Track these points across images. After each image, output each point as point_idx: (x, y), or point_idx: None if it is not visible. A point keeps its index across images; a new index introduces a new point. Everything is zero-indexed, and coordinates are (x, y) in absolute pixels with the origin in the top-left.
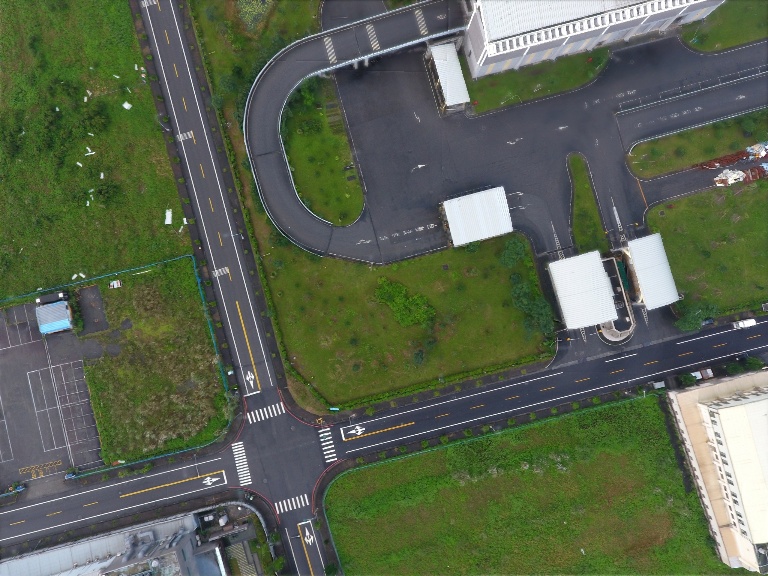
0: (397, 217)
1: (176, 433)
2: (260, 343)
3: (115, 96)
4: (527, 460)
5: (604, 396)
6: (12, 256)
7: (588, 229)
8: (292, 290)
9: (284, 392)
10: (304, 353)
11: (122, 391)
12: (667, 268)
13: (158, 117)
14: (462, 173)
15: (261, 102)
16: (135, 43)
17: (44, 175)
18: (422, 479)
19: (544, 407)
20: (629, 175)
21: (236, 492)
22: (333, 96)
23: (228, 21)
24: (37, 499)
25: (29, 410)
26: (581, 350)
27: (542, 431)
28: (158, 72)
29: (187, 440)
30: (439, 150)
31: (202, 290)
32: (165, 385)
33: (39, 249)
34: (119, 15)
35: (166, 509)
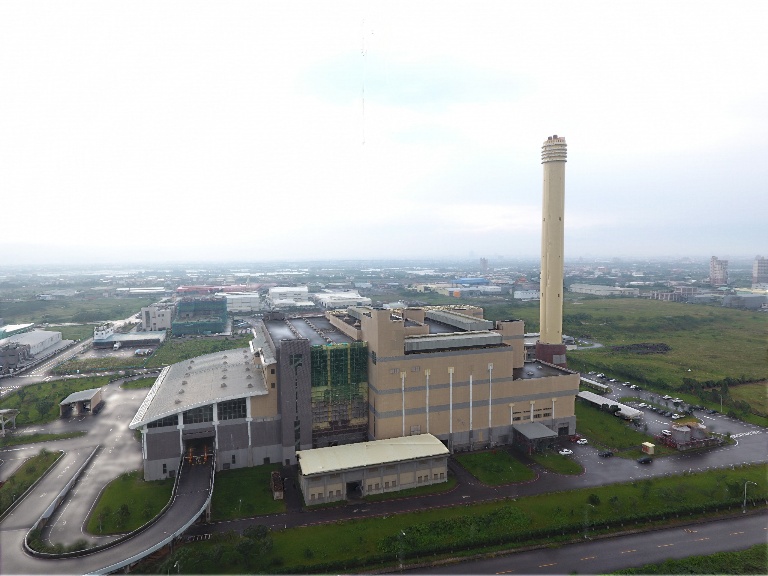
0: None
1: None
2: None
3: None
4: None
5: None
6: None
7: None
8: None
9: None
10: None
11: None
12: None
13: None
14: None
15: None
16: None
17: None
18: None
19: None
20: None
21: None
22: None
23: None
24: None
25: None
26: None
27: None
28: None
29: None
30: None
31: (124, 368)
32: None
33: None
34: None
35: (35, 367)
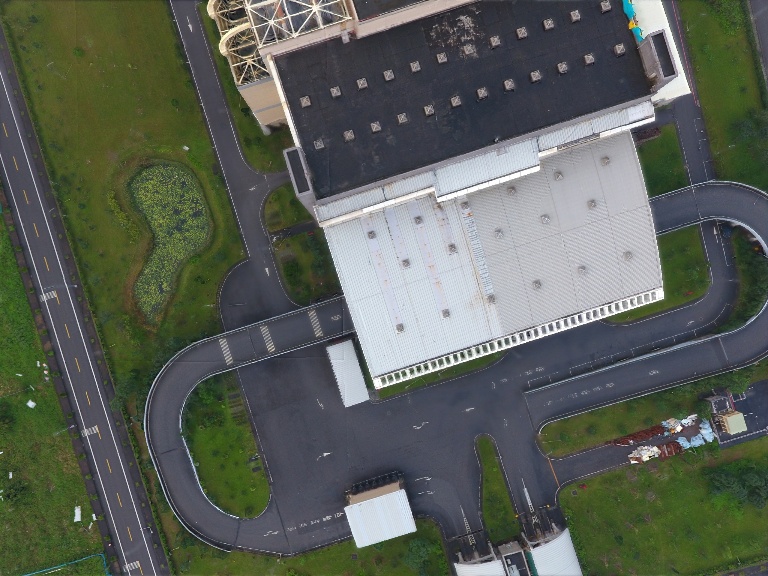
0: (304, 507)
1: None
2: None
3: (18, 396)
4: None
5: None
6: None
7: (498, 513)
8: None
9: None
10: None
11: None
12: (574, 569)
13: (62, 414)
14: (368, 460)
15: (161, 402)
16: (36, 339)
17: None
18: None
19: None
20: (540, 455)
21: None
22: (234, 388)
23: (126, 316)
24: None
25: None
26: None
27: None
28: (60, 367)
29: None
30: (344, 437)
31: None
32: None
33: None
34: (18, 313)
35: None
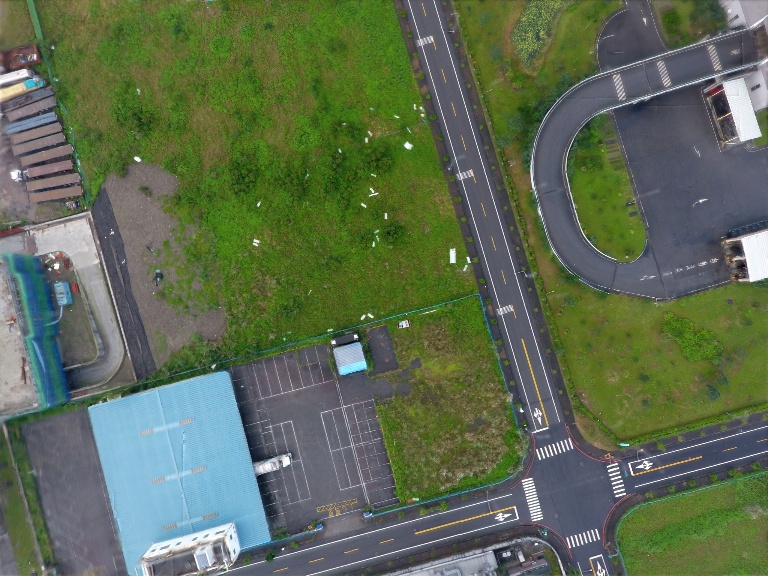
0: (680, 252)
1: (473, 471)
2: (546, 380)
3: (397, 136)
4: None
5: None
6: (303, 298)
7: None
8: (577, 327)
9: (572, 428)
10: (591, 389)
11: (415, 430)
12: None
13: (438, 156)
14: (743, 207)
15: (547, 140)
16: (413, 83)
17: (330, 217)
18: (712, 513)
19: None
20: None
21: (528, 527)
22: (614, 132)
23: (508, 59)
24: (334, 537)
25: (324, 450)
26: None
27: None
28: (436, 111)
29: (483, 477)
30: (720, 184)
31: (489, 328)
32: (456, 423)
33: (328, 290)
34: (397, 55)
35: (460, 545)
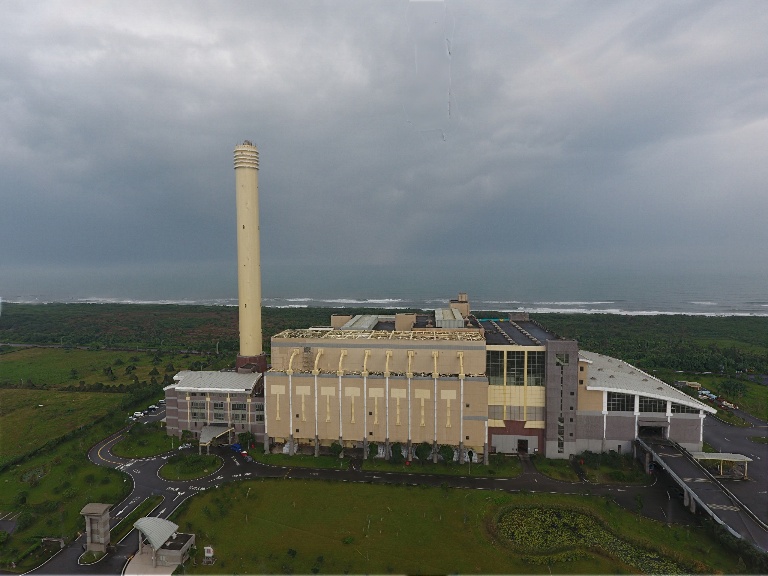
0: None
1: None
2: None
3: None
4: None
5: None
6: None
7: None
8: None
9: None
10: None
11: None
12: None
13: None
14: None
15: None
16: None
17: None
18: None
19: None
20: None
21: None
22: None
23: None
24: None
25: None
26: None
27: None
28: None
29: None
30: None
31: None
32: None
33: None
34: None
35: None
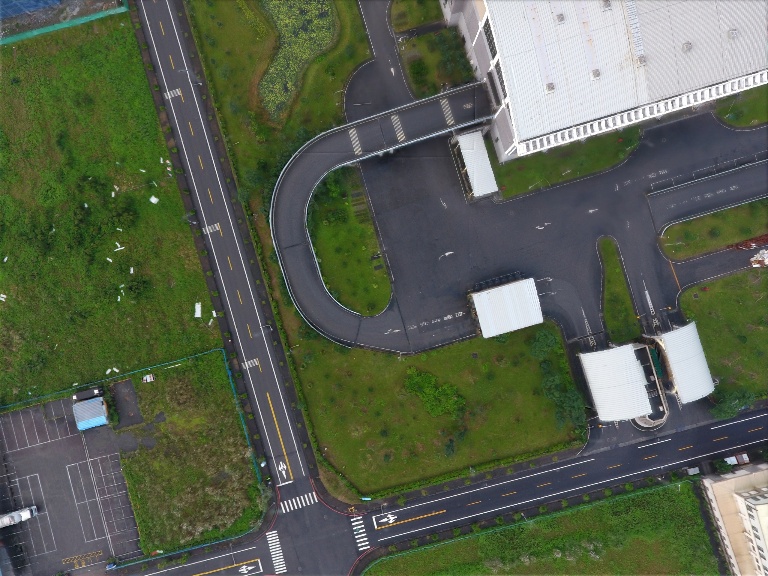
0: (425, 306)
1: (212, 525)
2: (291, 433)
3: (142, 191)
4: (559, 547)
5: (637, 482)
6: (48, 353)
7: (619, 314)
8: (322, 381)
9: (316, 482)
10: (335, 443)
11: (158, 483)
12: (702, 358)
13: (185, 210)
14: (490, 260)
15: (287, 195)
16: (160, 136)
17: (75, 272)
18: (454, 567)
19: (576, 494)
20: (661, 257)
21: None
22: (358, 185)
23: (251, 112)
24: None
25: (69, 502)
26: (613, 436)
27: (574, 518)
28: (183, 164)
29: (223, 531)
30: (466, 237)
31: (233, 383)
32: (200, 477)
33: (73, 345)
34: (143, 108)
35: None
